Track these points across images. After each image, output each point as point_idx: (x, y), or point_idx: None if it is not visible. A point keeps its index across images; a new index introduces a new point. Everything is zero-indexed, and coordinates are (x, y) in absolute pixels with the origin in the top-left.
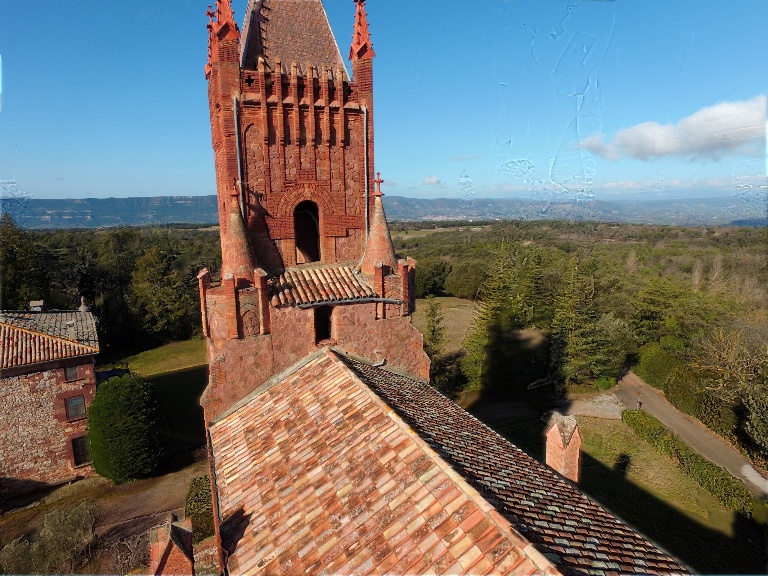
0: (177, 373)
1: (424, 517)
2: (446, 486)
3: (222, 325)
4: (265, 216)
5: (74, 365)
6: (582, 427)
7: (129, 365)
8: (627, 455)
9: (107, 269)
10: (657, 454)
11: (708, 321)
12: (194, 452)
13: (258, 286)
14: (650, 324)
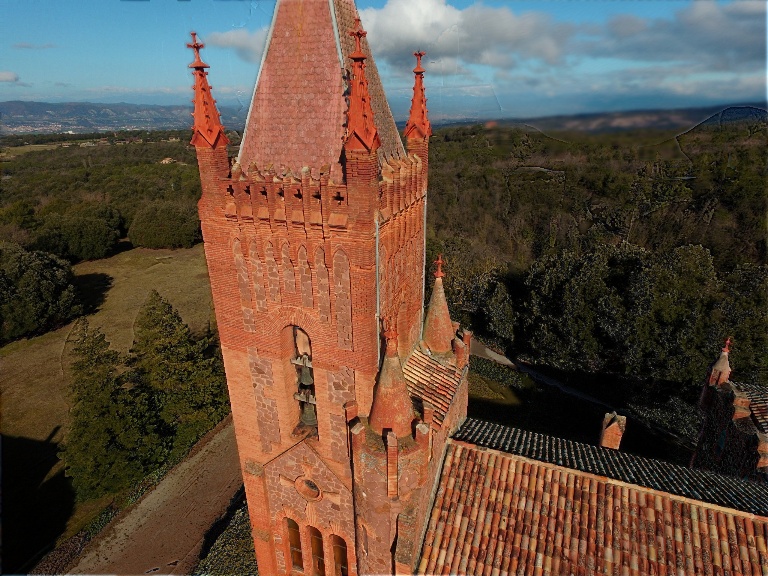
0: None
1: (726, 541)
2: (713, 515)
3: (413, 478)
4: (386, 338)
5: None
6: None
7: None
8: None
9: None
10: None
11: None
12: None
13: (430, 421)
14: None
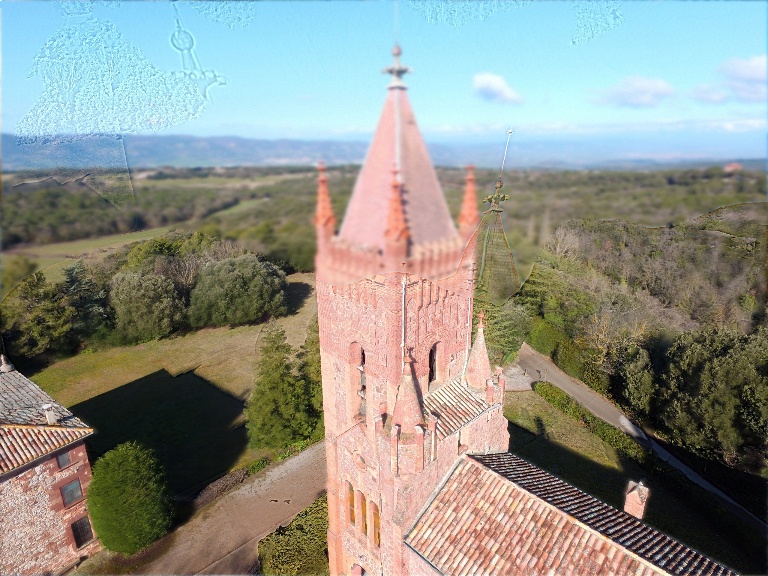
0: (95, 403)
1: None
2: None
3: (410, 464)
4: (414, 364)
5: (66, 451)
6: (510, 403)
7: None
8: (550, 424)
9: None
10: (567, 418)
11: (579, 301)
12: (197, 501)
13: (432, 429)
14: (534, 301)
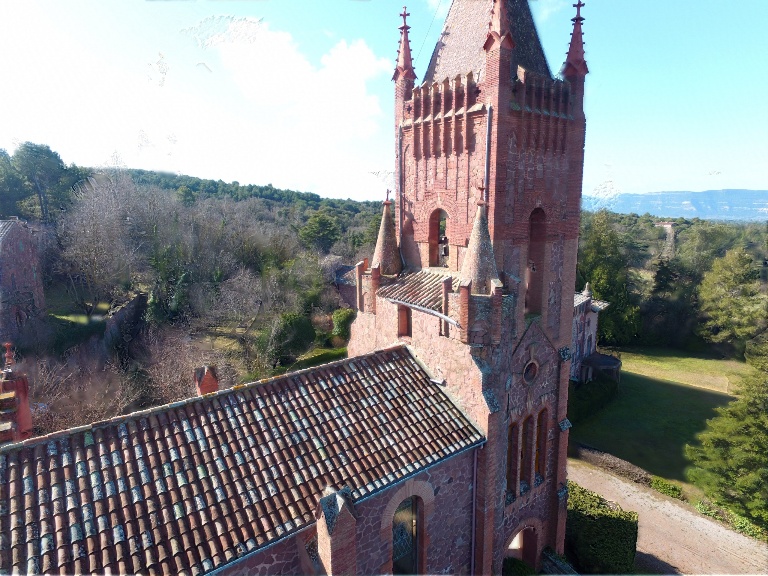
0: (691, 389)
1: None
2: None
3: None
4: (413, 221)
5: None
6: None
7: (662, 364)
8: None
9: (686, 266)
10: None
11: None
12: (582, 449)
13: None
14: None
